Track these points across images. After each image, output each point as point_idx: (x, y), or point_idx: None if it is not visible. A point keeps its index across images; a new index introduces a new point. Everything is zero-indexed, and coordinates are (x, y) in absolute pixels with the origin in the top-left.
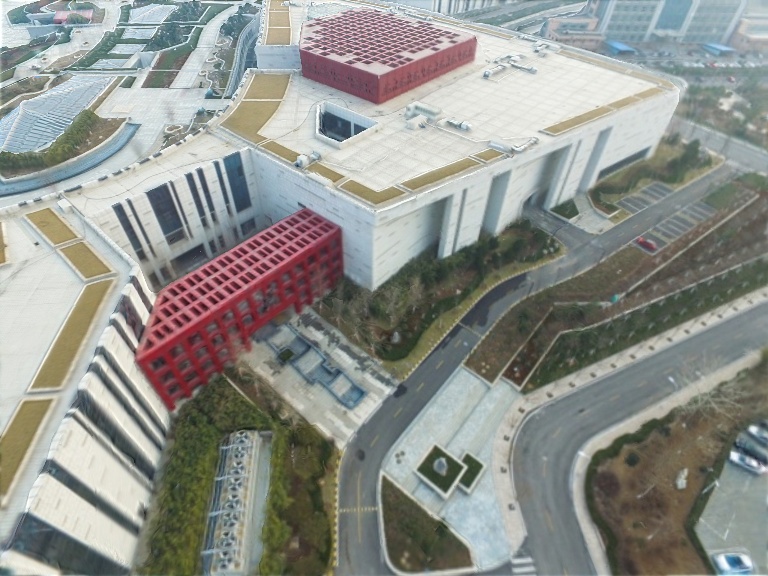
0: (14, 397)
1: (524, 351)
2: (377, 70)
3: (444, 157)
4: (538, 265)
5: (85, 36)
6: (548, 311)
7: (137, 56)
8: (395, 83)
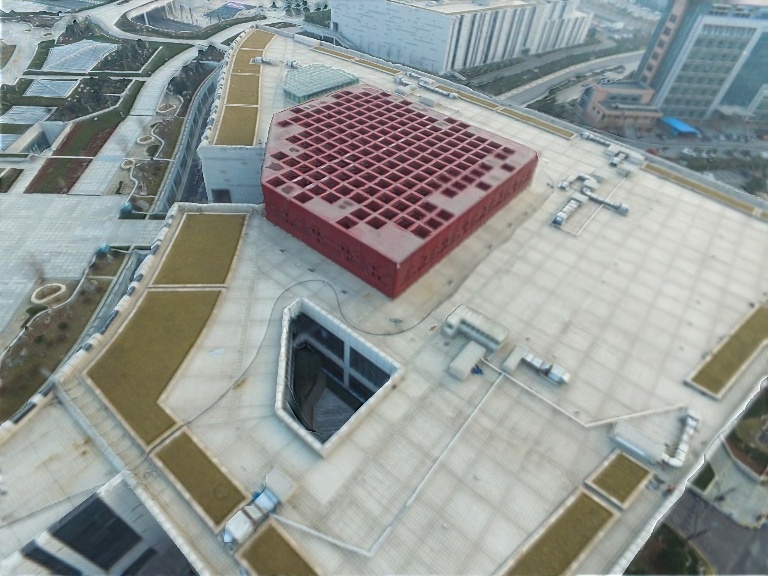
0: None
1: None
2: (394, 247)
3: (534, 486)
4: None
5: None
6: None
7: (38, 128)
8: (422, 260)
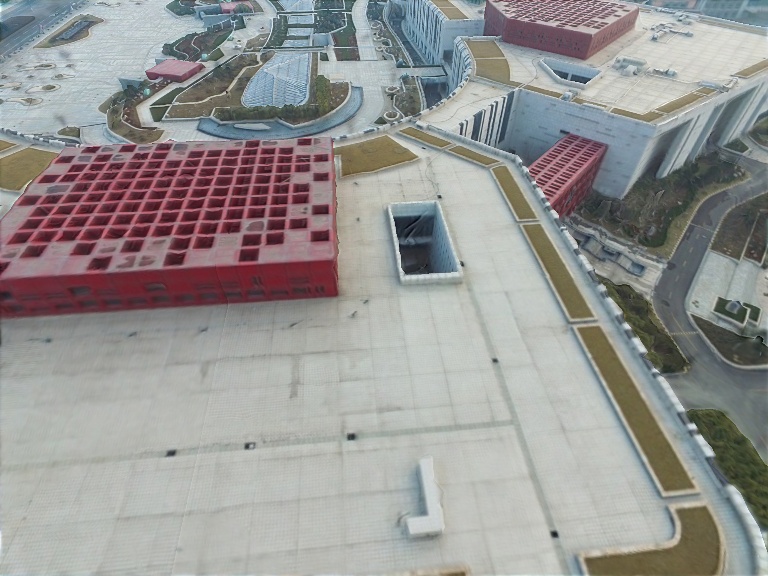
0: (510, 224)
1: (753, 240)
2: (588, 31)
3: (671, 93)
4: (732, 185)
5: (256, 23)
6: (757, 215)
7: (312, 37)
8: (597, 42)
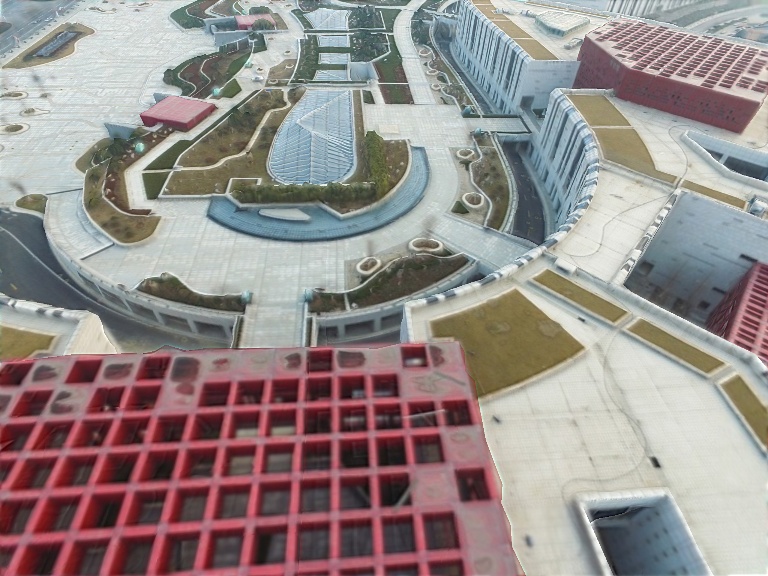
0: None
1: None
2: (751, 96)
3: None
4: None
5: (279, 43)
6: None
7: (349, 67)
8: None
